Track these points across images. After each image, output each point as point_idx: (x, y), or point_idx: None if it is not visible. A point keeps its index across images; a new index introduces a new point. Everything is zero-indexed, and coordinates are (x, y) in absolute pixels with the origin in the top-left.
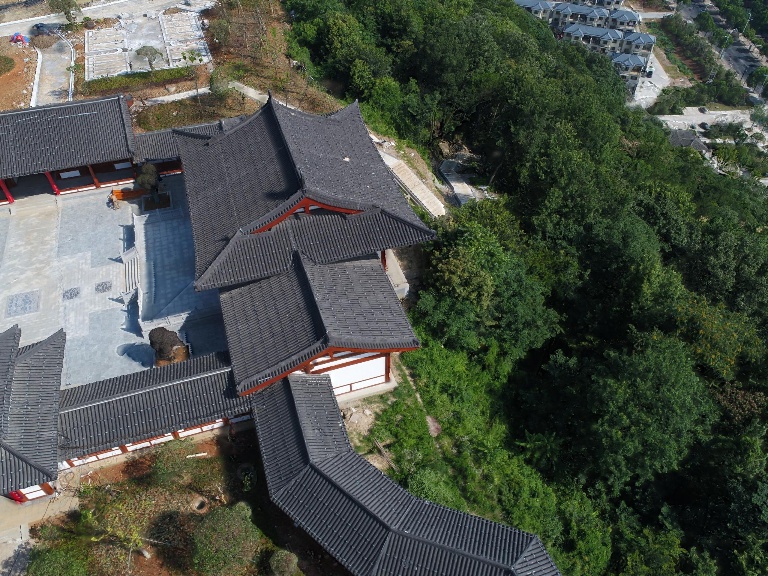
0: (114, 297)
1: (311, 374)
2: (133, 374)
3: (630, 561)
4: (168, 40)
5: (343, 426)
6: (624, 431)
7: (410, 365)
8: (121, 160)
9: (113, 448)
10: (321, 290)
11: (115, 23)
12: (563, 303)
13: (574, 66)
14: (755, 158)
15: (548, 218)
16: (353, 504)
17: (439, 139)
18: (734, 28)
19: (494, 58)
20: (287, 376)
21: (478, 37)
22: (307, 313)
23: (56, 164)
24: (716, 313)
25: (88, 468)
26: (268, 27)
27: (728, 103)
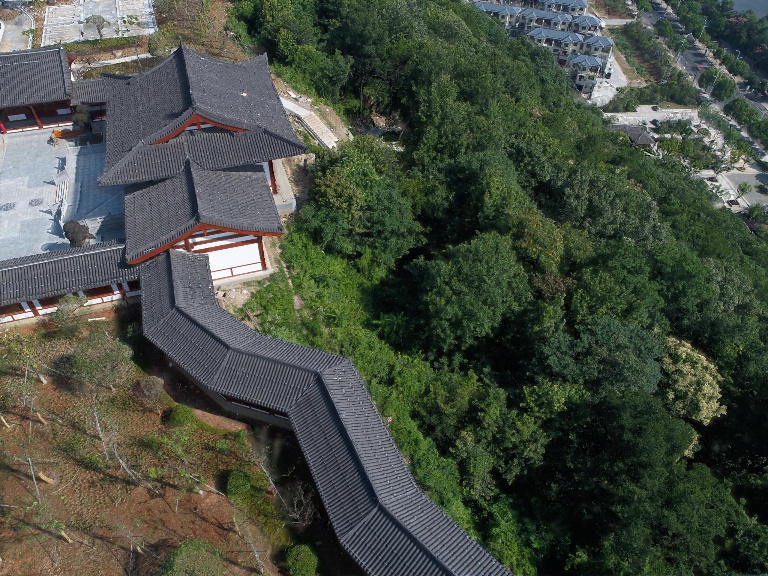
0: (44, 210)
1: (192, 252)
2: (46, 253)
3: (432, 387)
4: (121, 15)
5: (212, 288)
6: (447, 300)
7: (287, 260)
8: (63, 106)
9: (26, 310)
10: (204, 187)
11: (74, 1)
12: (435, 223)
13: (516, 57)
14: (700, 152)
15: (426, 153)
16: (205, 333)
17: (369, 109)
18: (692, 34)
19: (414, 34)
20: (169, 250)
21: (397, 14)
22: (189, 202)
23: (1, 103)
24: (548, 221)
25: (5, 326)
26: (212, 5)
27: (680, 102)
